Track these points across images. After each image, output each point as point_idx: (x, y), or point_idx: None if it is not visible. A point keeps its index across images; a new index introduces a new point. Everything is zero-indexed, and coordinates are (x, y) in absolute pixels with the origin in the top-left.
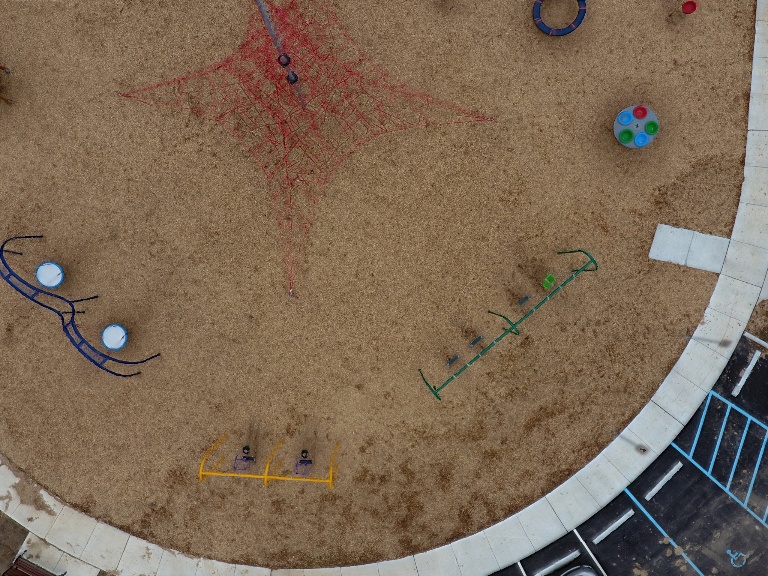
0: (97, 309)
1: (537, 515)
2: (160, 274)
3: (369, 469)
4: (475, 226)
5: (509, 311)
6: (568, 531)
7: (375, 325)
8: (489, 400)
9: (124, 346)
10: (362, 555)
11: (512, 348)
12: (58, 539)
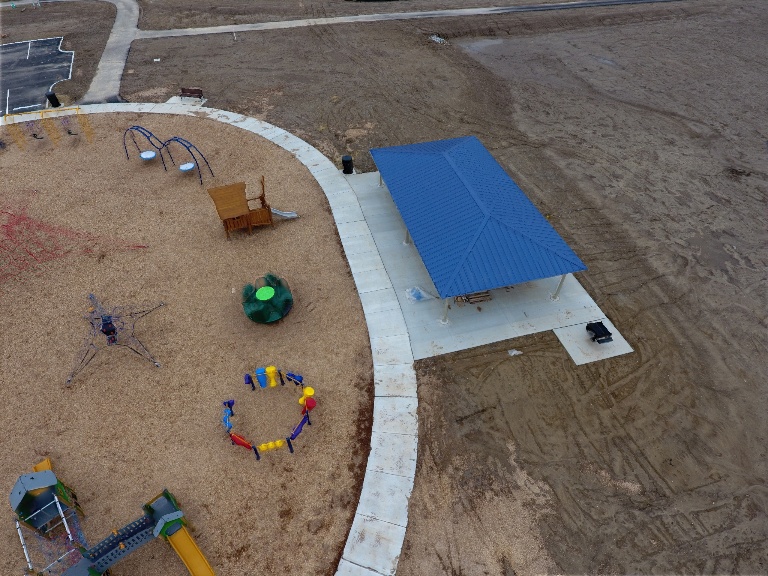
0: None
1: None
2: None
3: (6, 146)
4: None
5: None
6: None
7: None
8: None
9: None
10: None
11: None
12: None
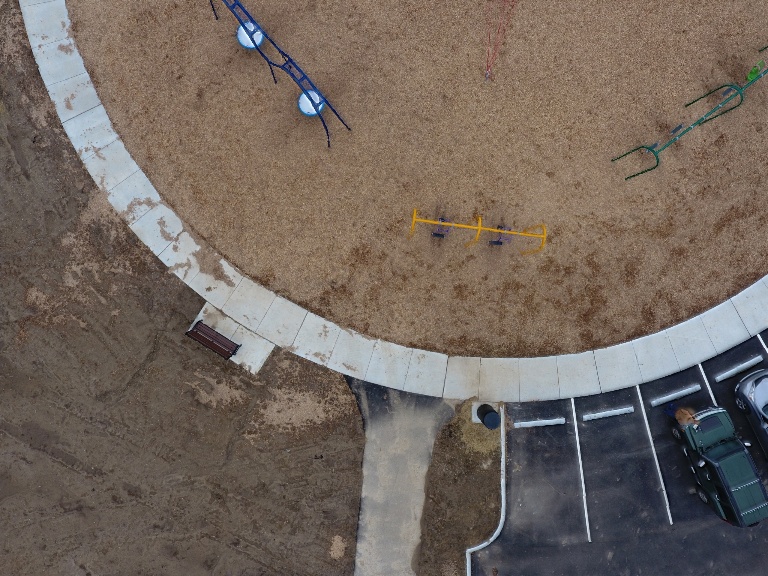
0: (289, 80)
1: (721, 317)
2: (356, 47)
3: (554, 259)
4: (677, 19)
5: (706, 107)
6: (751, 336)
7: (569, 114)
8: (680, 197)
9: (314, 119)
10: (541, 347)
11: (706, 146)
12: (235, 311)
